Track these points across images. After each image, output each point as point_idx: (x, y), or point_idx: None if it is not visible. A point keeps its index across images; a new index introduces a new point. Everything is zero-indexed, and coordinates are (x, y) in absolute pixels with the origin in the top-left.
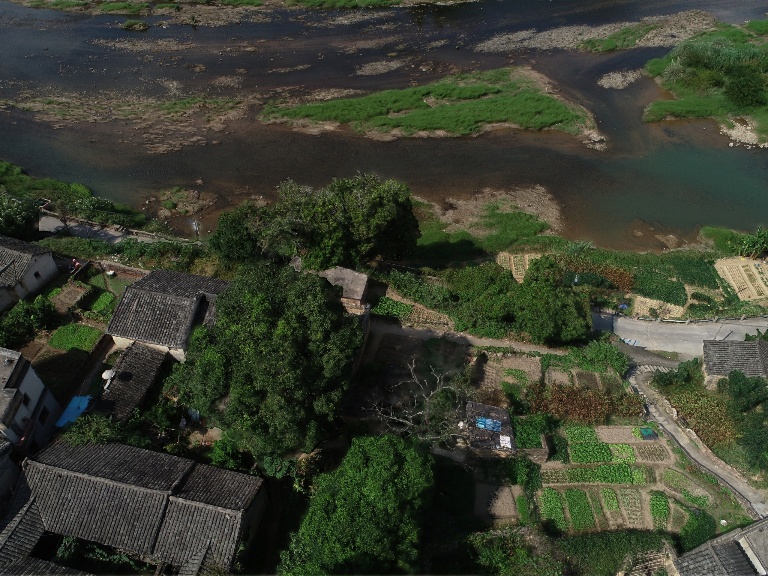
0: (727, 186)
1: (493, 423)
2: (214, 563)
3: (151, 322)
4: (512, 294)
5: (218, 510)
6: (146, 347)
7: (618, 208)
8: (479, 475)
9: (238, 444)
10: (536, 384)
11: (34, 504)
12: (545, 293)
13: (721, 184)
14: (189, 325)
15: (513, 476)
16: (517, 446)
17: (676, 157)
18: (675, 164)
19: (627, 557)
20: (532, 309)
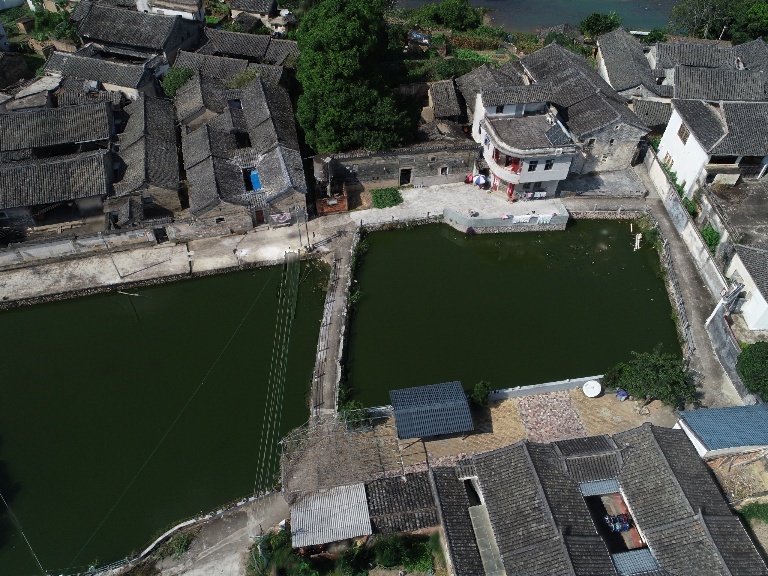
0: (605, 13)
1: (420, 36)
2: (291, 59)
3: (252, 2)
4: (439, 5)
5: (293, 42)
6: (249, 15)
7: (529, 20)
8: (413, 58)
9: (301, 18)
10: (447, 37)
11: (211, 43)
12: (456, 2)
13: (601, 12)
14: (271, 5)
15: (428, 56)
16: (431, 43)
17: (576, 0)
18: (574, 4)
19: (473, 68)
20: (447, 4)
